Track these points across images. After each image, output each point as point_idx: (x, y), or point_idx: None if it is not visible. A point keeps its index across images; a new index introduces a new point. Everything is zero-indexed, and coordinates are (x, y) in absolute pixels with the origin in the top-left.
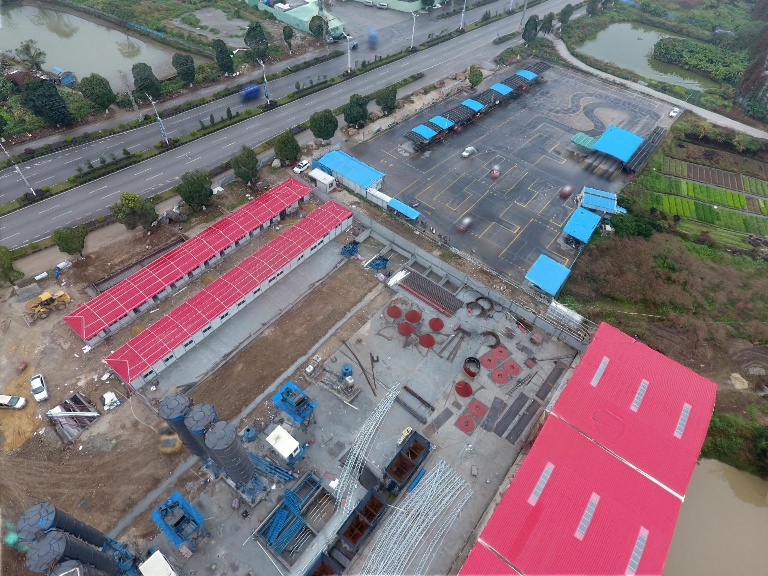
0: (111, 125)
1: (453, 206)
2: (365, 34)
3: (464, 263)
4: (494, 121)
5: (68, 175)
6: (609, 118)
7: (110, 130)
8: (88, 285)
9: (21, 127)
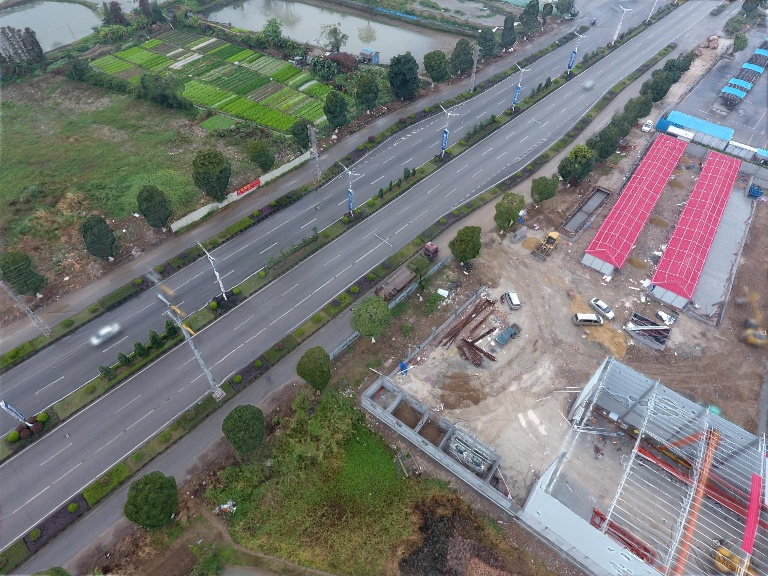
0: (446, 97)
1: None
2: (590, 11)
3: None
4: None
5: (450, 140)
6: None
7: (453, 101)
8: (554, 229)
9: (376, 101)
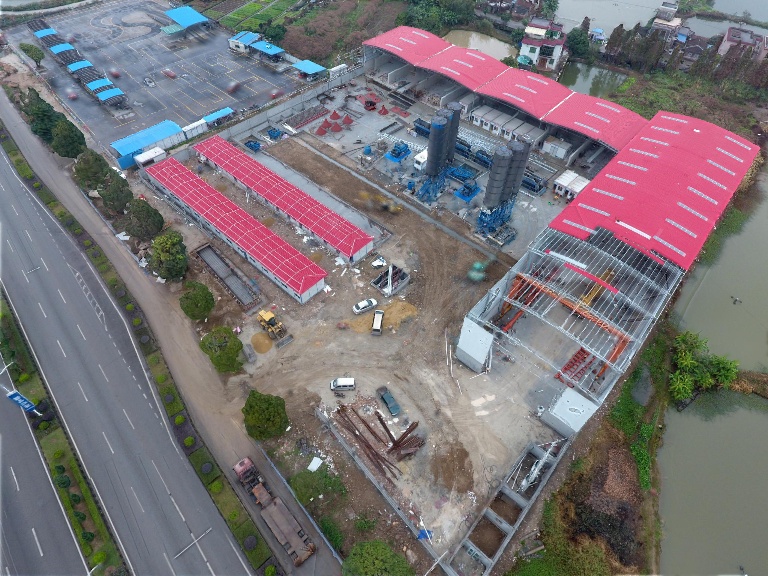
0: None
1: (218, 99)
2: None
3: (282, 102)
4: (107, 66)
5: (1, 395)
6: (140, 19)
7: None
8: None
9: None
